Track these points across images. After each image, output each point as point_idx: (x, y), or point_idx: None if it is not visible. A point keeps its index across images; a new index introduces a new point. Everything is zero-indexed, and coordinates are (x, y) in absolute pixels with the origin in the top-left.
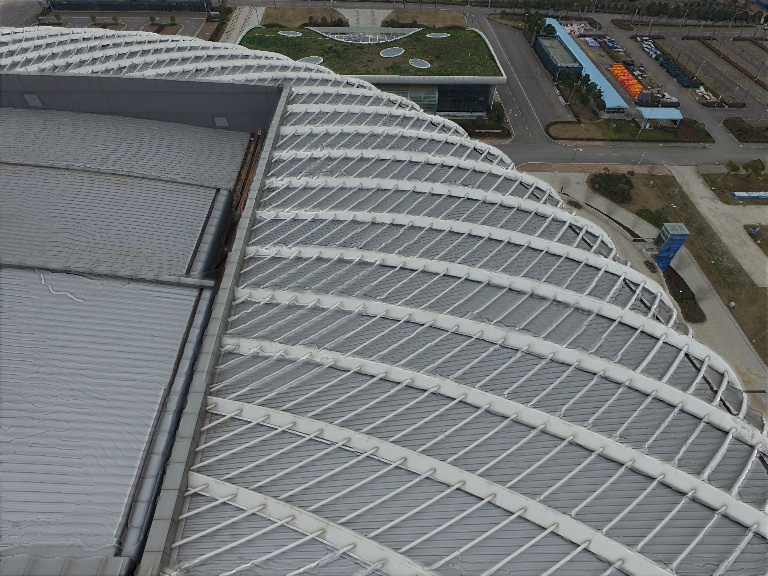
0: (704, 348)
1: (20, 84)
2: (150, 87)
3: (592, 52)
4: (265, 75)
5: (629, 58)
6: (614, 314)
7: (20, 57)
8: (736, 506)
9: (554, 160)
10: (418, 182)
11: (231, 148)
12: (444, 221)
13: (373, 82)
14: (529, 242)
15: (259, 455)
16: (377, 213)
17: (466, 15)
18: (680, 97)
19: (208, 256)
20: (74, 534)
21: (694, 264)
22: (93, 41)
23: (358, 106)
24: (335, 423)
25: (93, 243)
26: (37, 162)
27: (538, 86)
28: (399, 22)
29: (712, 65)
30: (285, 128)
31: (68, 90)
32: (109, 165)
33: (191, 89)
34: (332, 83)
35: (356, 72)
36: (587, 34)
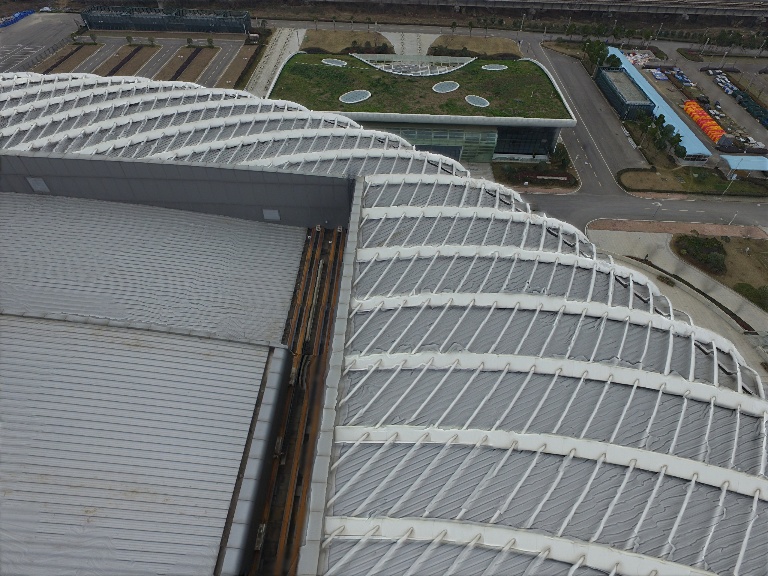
0: None
1: (22, 167)
2: (184, 174)
3: (660, 86)
4: (328, 155)
5: (702, 94)
6: None
7: (28, 124)
8: None
9: (630, 216)
10: (565, 361)
11: (283, 252)
12: (622, 448)
13: (426, 121)
14: (759, 490)
15: None
16: (520, 434)
17: (520, 42)
18: (766, 142)
19: (258, 486)
20: None
21: None
22: (119, 100)
23: (453, 208)
24: None
25: (88, 469)
26: (33, 282)
27: (604, 125)
28: (448, 48)
29: None
30: (363, 251)
31: (81, 175)
32: (126, 286)
33: (236, 178)
34: (411, 165)
35: (407, 110)
36: (652, 65)
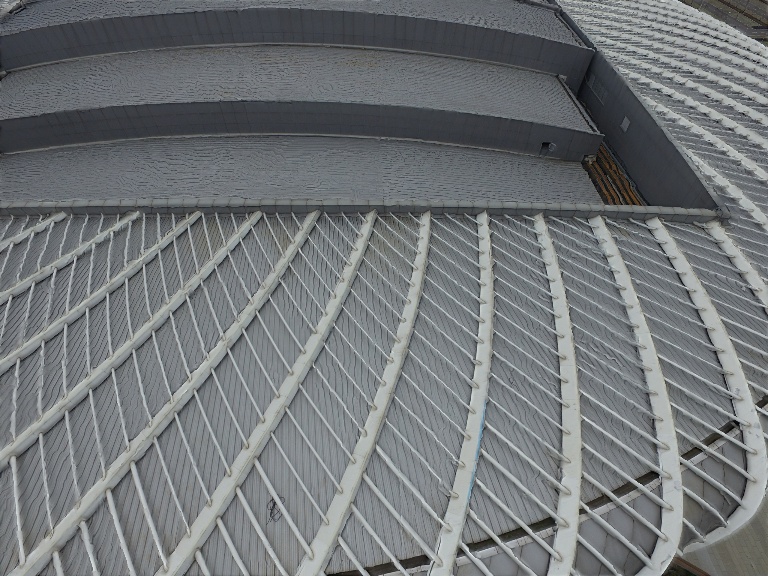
0: None
1: None
2: None
3: None
4: None
5: None
6: (675, 4)
7: None
8: (720, 27)
9: None
10: None
11: None
12: None
13: None
14: None
15: (576, 4)
16: None
17: None
18: None
19: None
20: (544, 1)
21: None
22: None
23: None
24: (594, 3)
25: None
26: None
27: None
28: None
29: (711, 5)
30: None
31: None
32: None
33: None
34: None
35: None
36: None
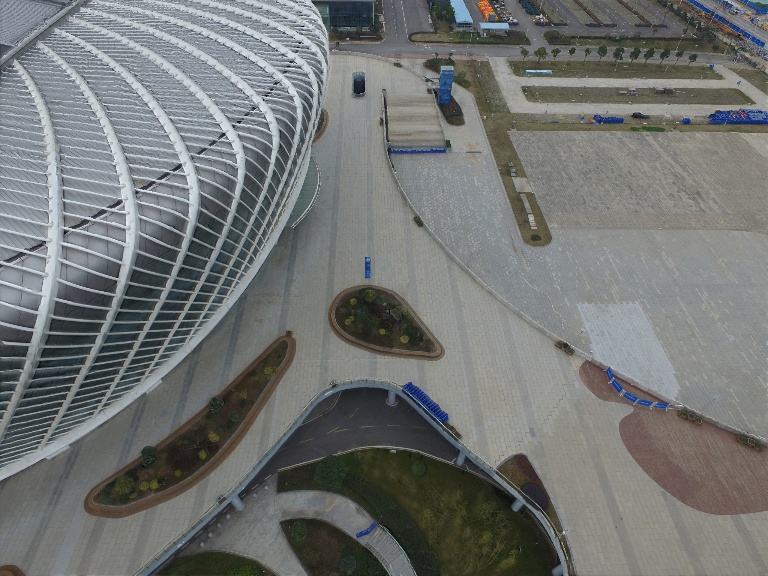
0: (309, 11)
1: None
2: None
3: None
4: None
5: None
6: None
7: None
8: (273, 23)
9: (407, 52)
10: None
11: None
12: None
13: None
14: None
15: None
16: None
17: None
18: (522, 20)
19: None
20: None
21: (473, 101)
22: None
23: None
24: None
25: None
26: None
27: (416, 13)
28: None
29: (560, 2)
30: None
31: None
32: None
33: None
34: None
35: None
36: None
